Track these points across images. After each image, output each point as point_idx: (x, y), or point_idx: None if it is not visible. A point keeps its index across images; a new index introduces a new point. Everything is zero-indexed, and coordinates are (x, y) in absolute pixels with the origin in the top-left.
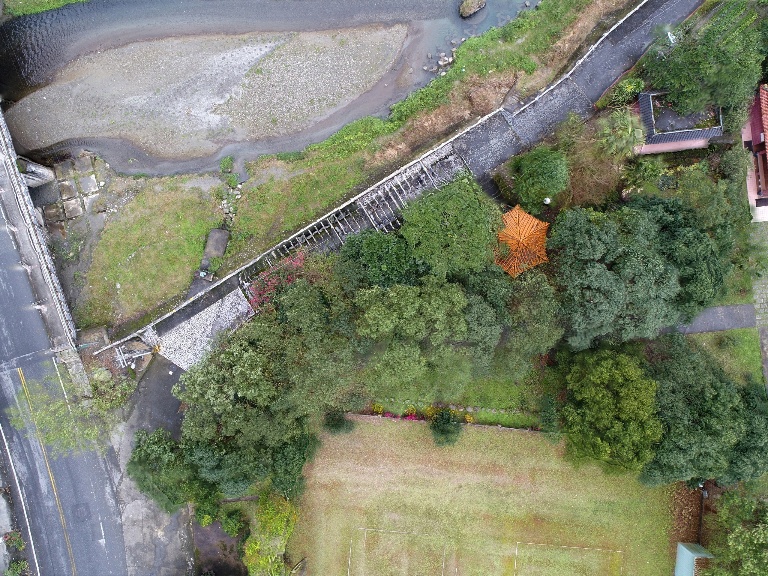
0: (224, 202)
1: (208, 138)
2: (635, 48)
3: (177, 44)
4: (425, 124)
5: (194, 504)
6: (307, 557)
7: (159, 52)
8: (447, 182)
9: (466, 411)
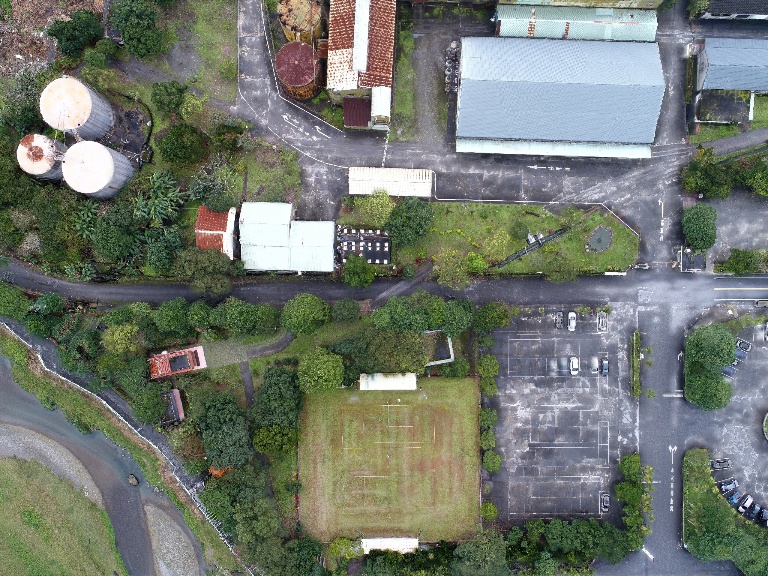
0: (224, 573)
1: None
2: None
3: None
4: (183, 499)
5: None
6: (357, 530)
7: None
8: None
9: None
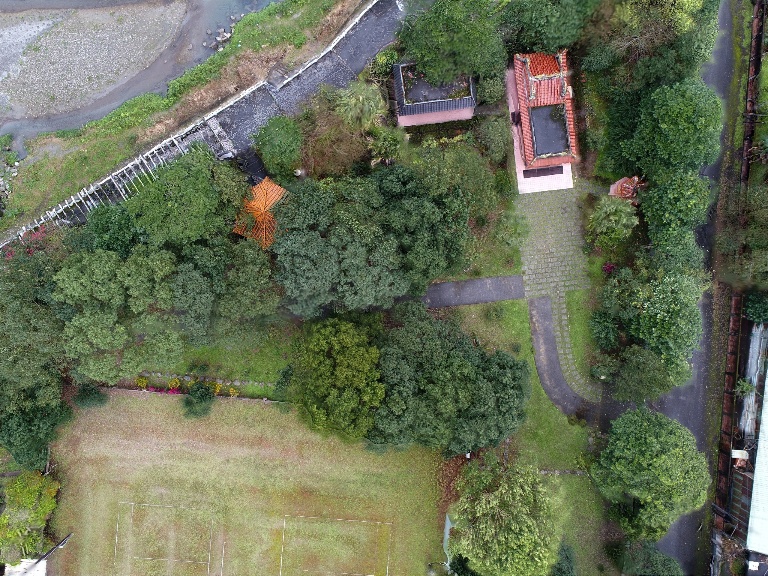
0: (0, 180)
1: None
2: (399, 20)
3: None
4: (195, 99)
5: None
6: (74, 532)
7: None
8: None
9: (233, 385)
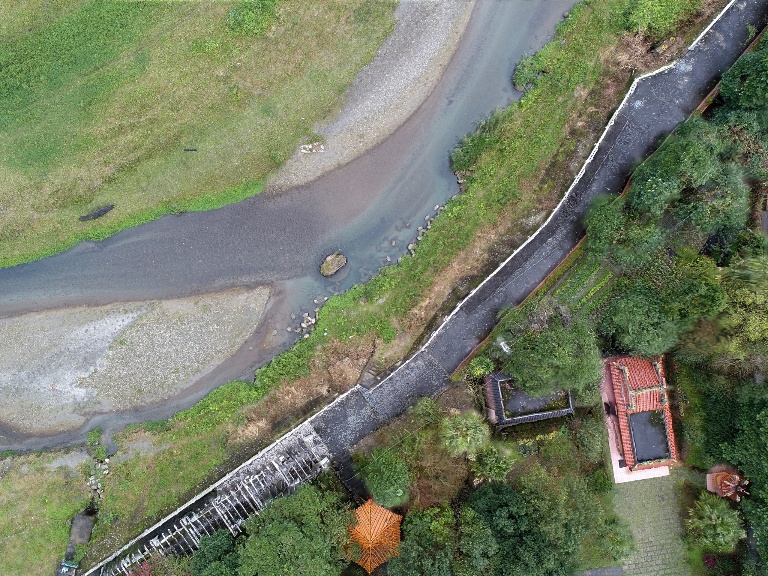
0: (92, 478)
1: (75, 411)
2: (489, 316)
3: (39, 319)
4: (286, 398)
5: None
6: None
7: (22, 328)
8: (305, 465)
9: None
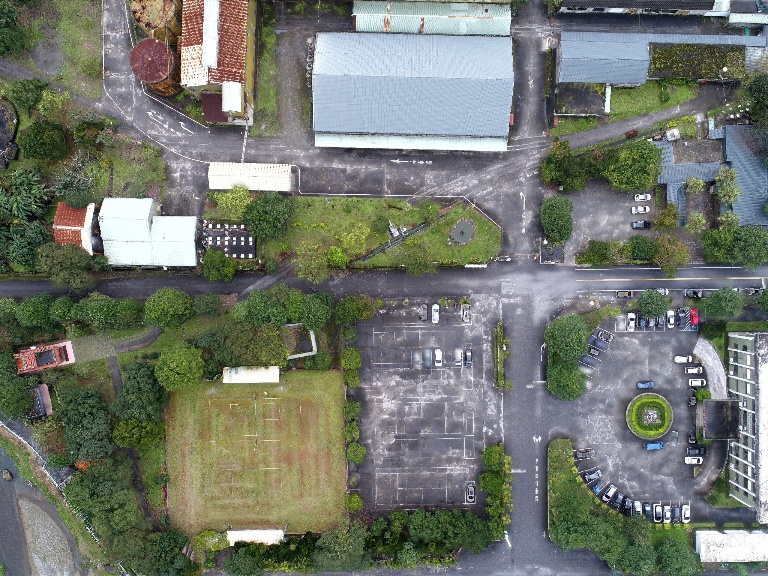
0: (98, 567)
1: (74, 575)
2: None
3: None
4: None
5: (208, 569)
6: (225, 523)
7: None
8: None
9: None
